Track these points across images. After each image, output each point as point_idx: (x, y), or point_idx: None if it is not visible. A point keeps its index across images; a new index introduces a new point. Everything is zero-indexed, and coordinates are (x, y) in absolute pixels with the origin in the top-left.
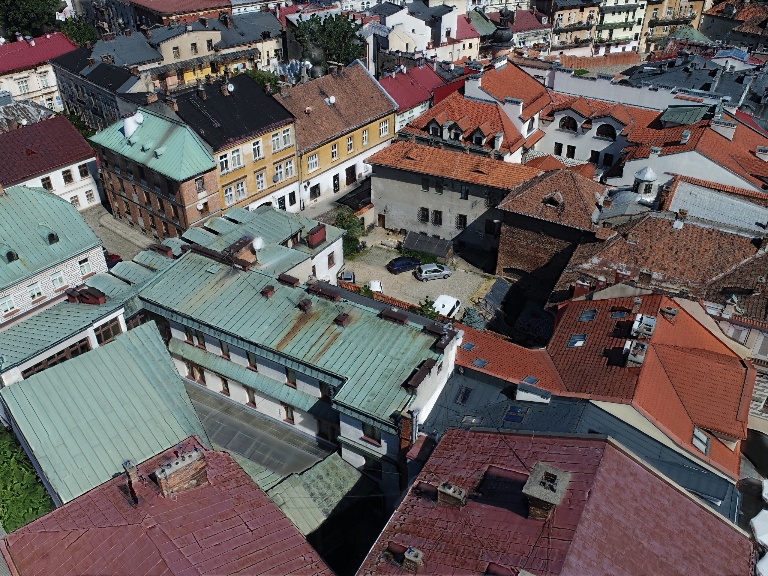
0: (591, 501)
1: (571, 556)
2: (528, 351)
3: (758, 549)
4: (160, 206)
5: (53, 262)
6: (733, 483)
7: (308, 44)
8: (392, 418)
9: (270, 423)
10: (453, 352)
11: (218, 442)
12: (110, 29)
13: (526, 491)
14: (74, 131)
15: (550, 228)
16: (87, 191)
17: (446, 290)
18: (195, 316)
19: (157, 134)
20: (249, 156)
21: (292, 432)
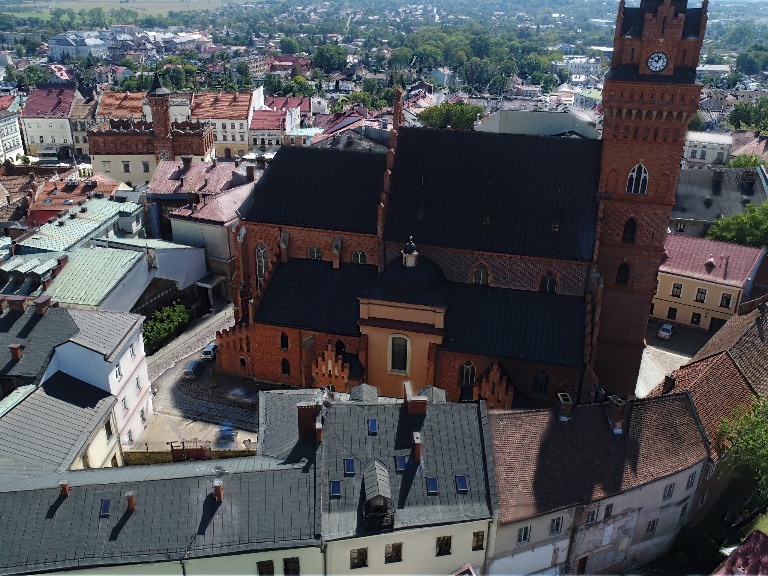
0: None
1: None
2: None
3: None
4: None
5: None
6: None
7: None
8: (140, 204)
9: None
10: None
11: None
12: None
13: (191, 157)
14: None
15: None
16: None
17: None
18: (80, 238)
19: None
20: None
21: None
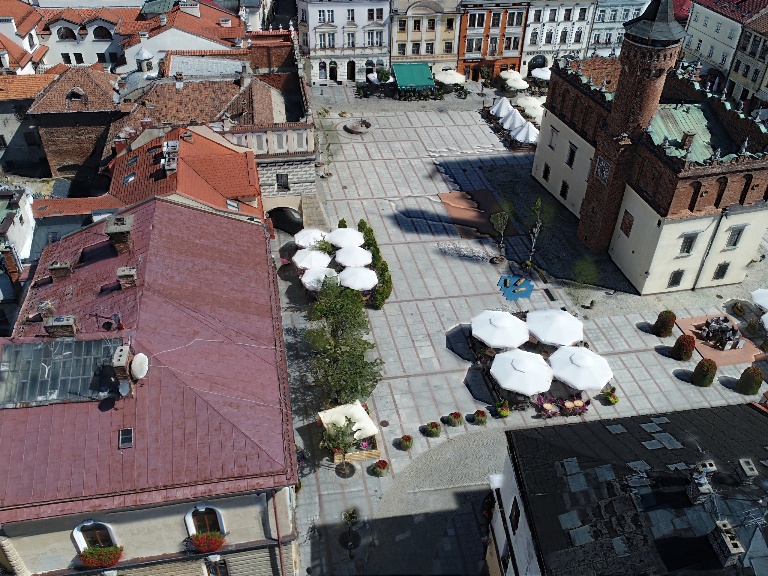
0: (155, 230)
1: (151, 257)
2: (94, 198)
3: (302, 274)
4: None
5: None
6: (259, 221)
7: None
8: None
9: None
10: (28, 208)
11: None
12: None
13: (106, 232)
14: None
15: (82, 119)
16: None
17: None
18: None
19: None
20: None
21: None
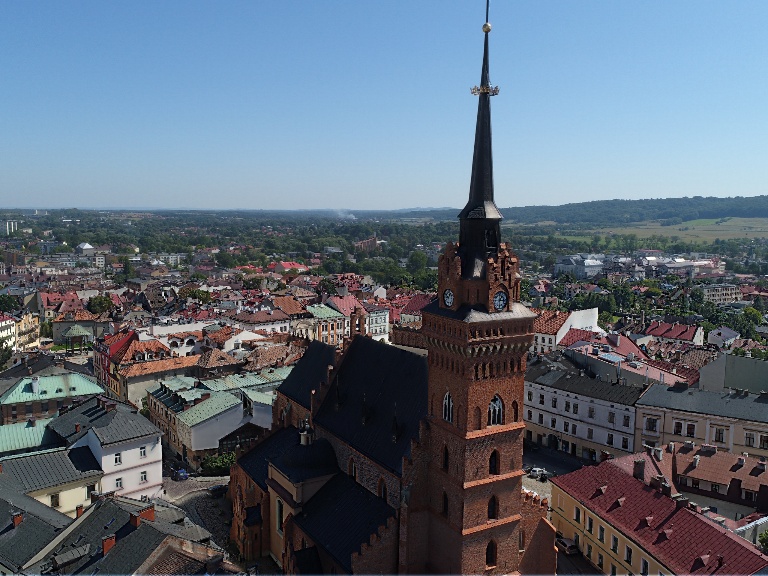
0: None
1: None
2: None
3: None
4: None
5: None
6: None
7: None
8: None
9: None
10: None
11: None
12: None
13: None
14: None
15: (226, 369)
16: None
17: None
18: None
19: (58, 383)
20: None
21: None
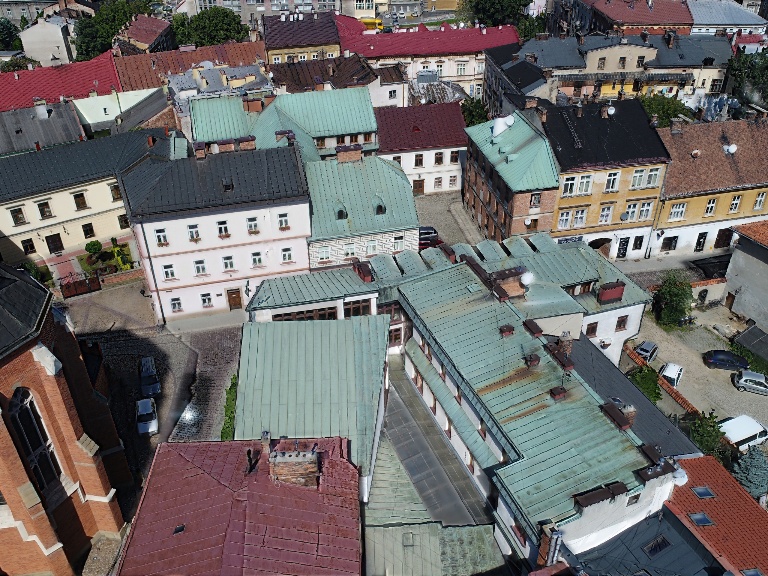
0: None
1: None
2: None
3: None
4: (496, 209)
5: (372, 230)
6: None
7: (743, 80)
8: (540, 525)
9: (455, 460)
10: (664, 489)
11: (399, 453)
12: (568, 29)
13: None
14: (461, 119)
15: None
16: (452, 176)
17: (762, 411)
18: (429, 326)
19: (518, 140)
20: (600, 185)
21: (469, 480)
